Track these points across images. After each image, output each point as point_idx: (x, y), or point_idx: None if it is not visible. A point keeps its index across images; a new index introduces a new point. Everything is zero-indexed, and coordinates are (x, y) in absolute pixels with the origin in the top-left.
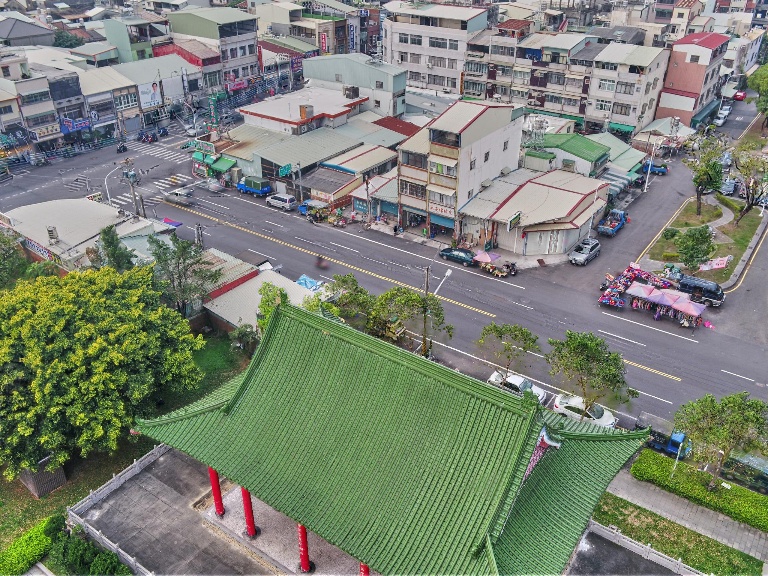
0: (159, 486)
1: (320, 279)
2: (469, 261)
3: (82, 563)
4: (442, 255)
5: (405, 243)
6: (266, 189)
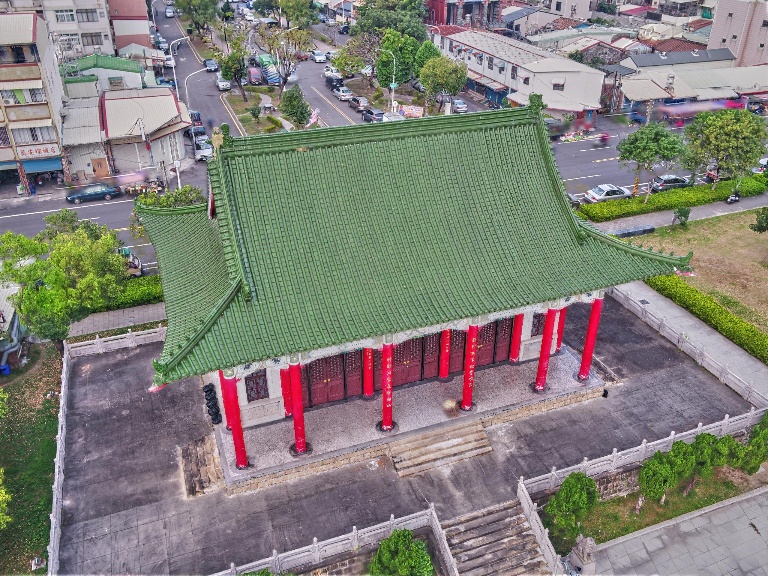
0: (114, 519)
1: None
2: (111, 192)
3: None
4: (72, 200)
5: (7, 209)
6: None
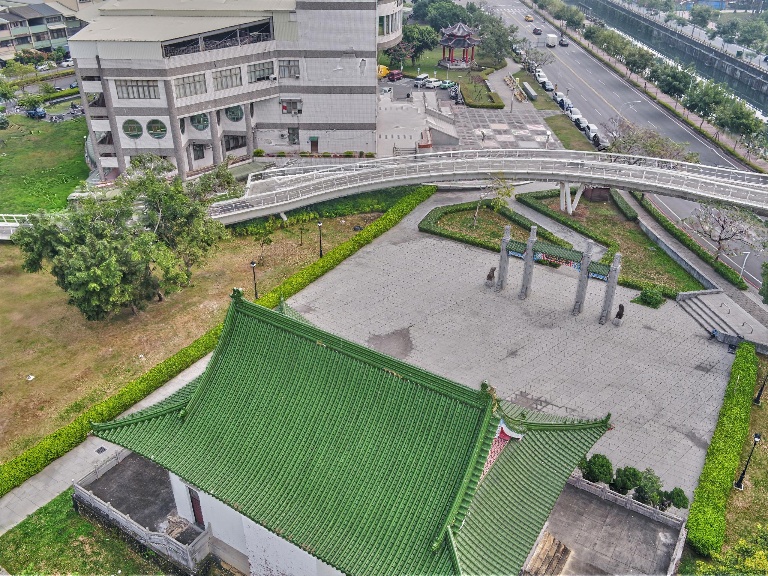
0: (623, 574)
1: None
2: None
3: None
4: None
5: None
6: None
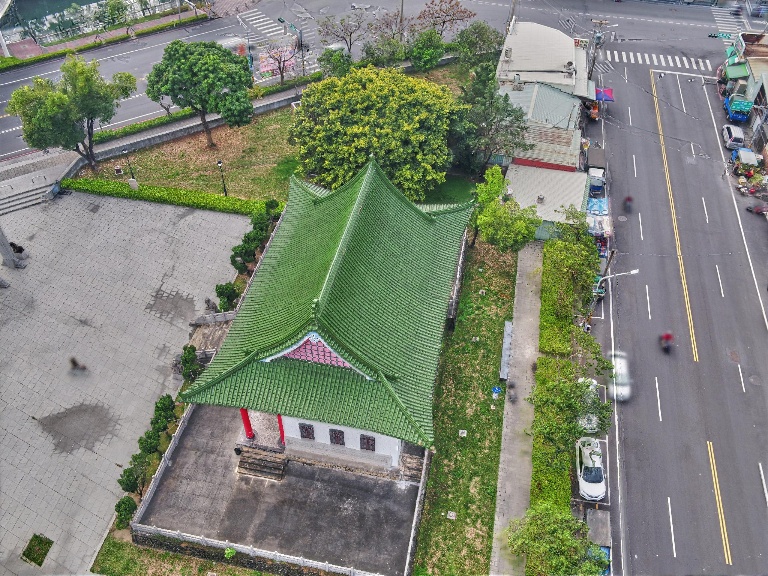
0: None
1: (634, 215)
2: None
3: (255, 227)
4: None
5: (766, 249)
6: (740, 117)
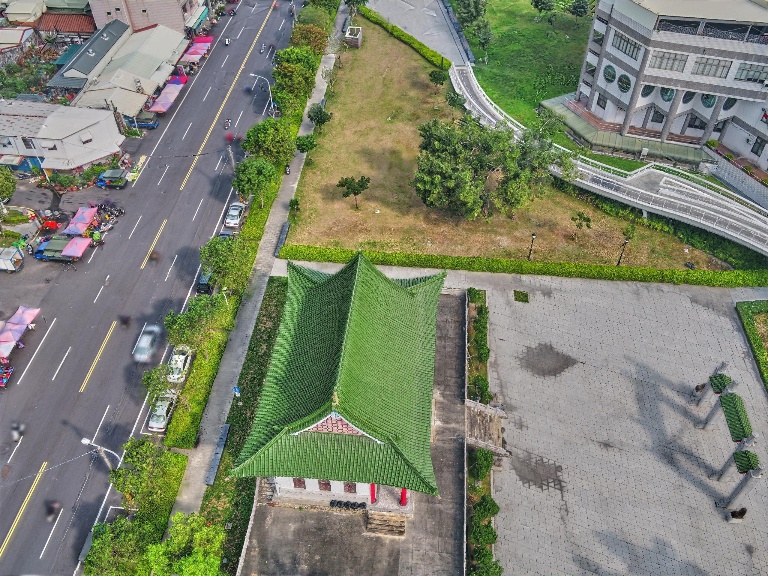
0: (403, 573)
1: None
2: None
3: None
4: None
5: None
6: None
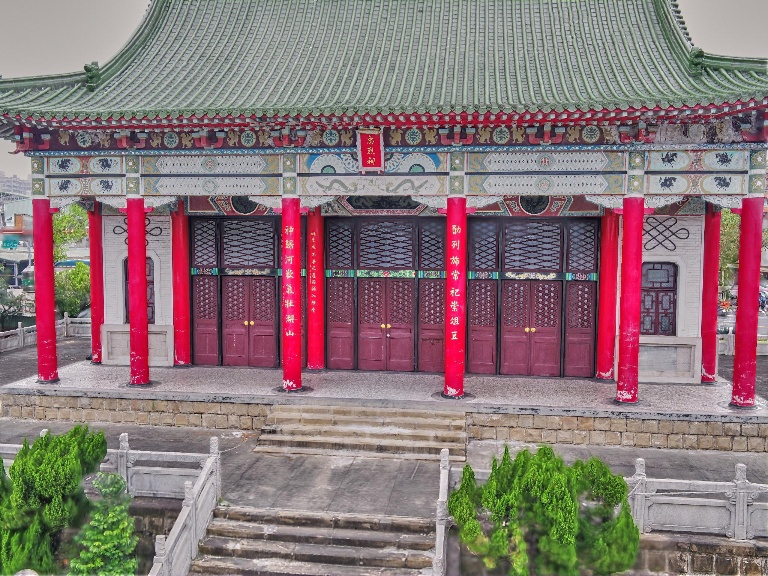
0: None
1: None
2: None
3: None
4: None
5: None
6: None
